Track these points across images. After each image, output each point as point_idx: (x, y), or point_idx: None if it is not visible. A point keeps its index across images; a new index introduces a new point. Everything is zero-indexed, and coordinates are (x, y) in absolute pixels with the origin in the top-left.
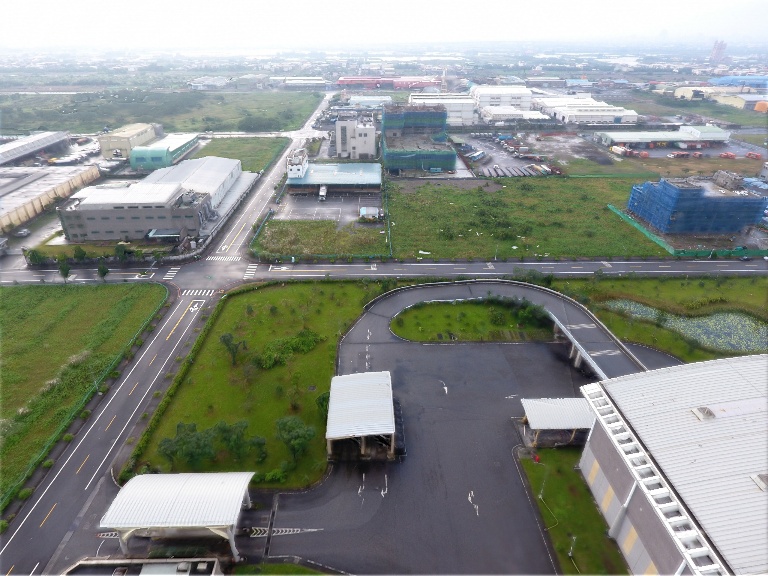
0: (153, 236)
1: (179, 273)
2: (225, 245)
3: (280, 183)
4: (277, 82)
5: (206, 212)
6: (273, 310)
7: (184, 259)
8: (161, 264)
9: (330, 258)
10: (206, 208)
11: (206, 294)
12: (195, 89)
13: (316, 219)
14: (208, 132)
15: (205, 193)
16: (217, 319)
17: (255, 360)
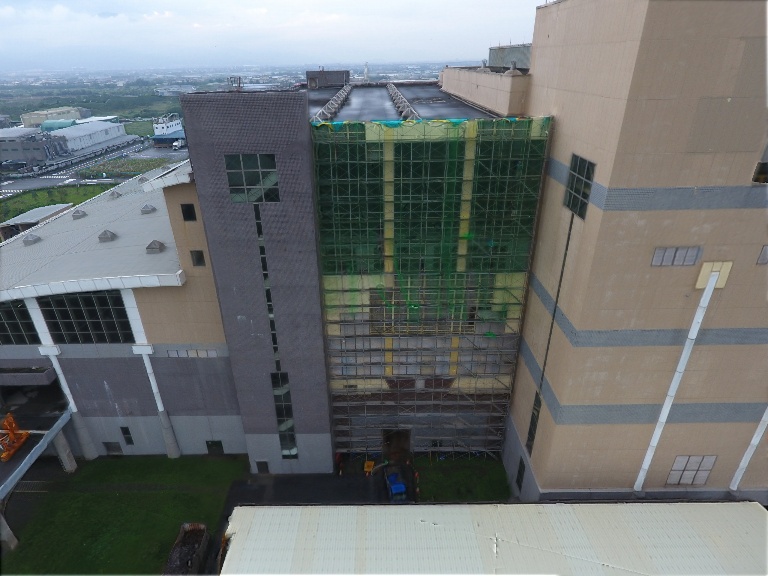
0: (5, 163)
1: (10, 183)
2: (64, 171)
3: (153, 141)
4: (238, 88)
5: (57, 149)
6: (49, 193)
7: (22, 177)
8: (1, 180)
9: (135, 175)
10: (56, 145)
11: (17, 191)
12: (161, 95)
13: (155, 158)
14: (136, 118)
15: (61, 136)
16: (8, 200)
17: (4, 211)
